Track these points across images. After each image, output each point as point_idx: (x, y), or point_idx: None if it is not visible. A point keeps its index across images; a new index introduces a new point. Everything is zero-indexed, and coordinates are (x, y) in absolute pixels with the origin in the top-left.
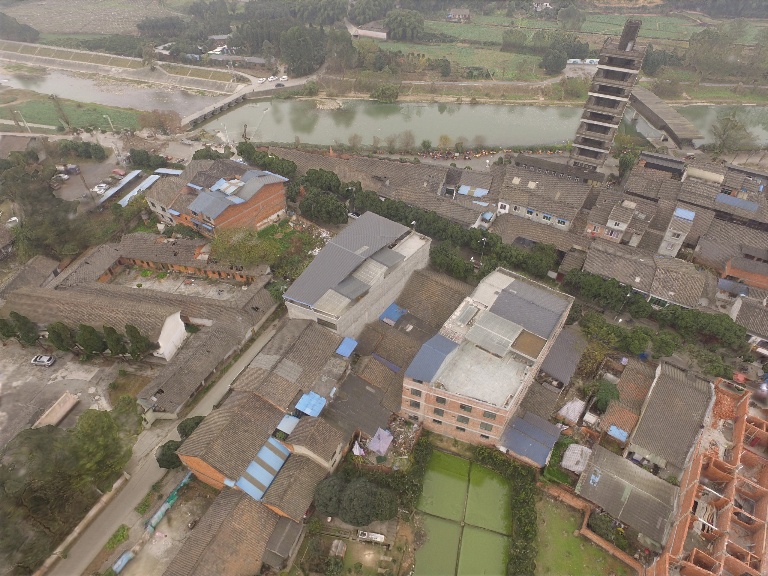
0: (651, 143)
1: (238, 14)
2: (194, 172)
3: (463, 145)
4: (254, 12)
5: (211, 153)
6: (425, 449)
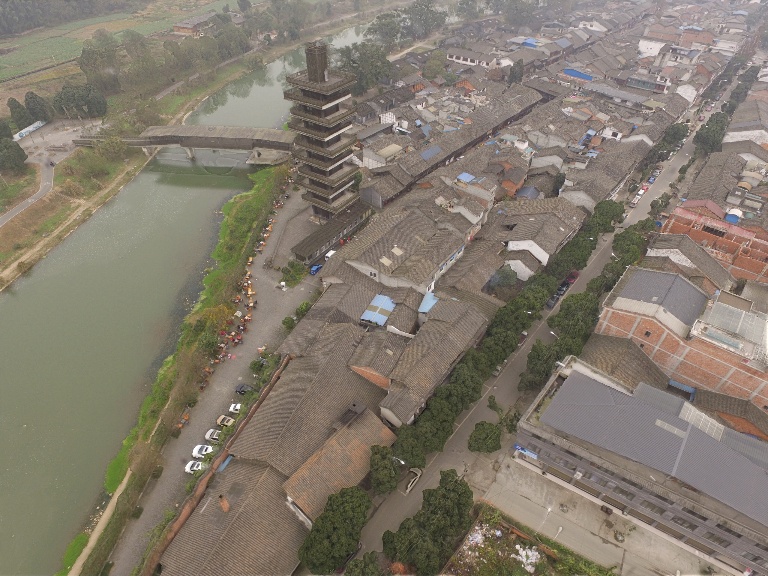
0: (257, 164)
1: None
2: None
3: (172, 309)
4: None
5: None
6: None
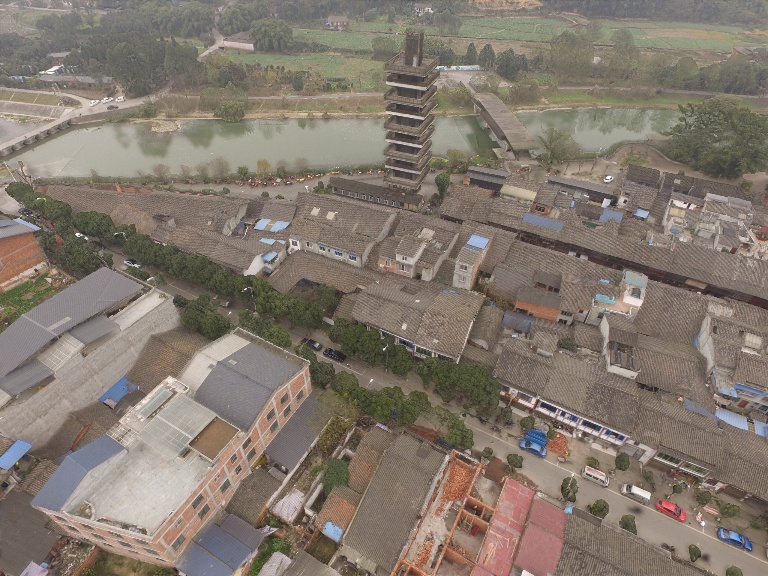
0: (495, 154)
1: (96, 27)
2: None
3: (299, 167)
4: (110, 25)
5: None
6: None
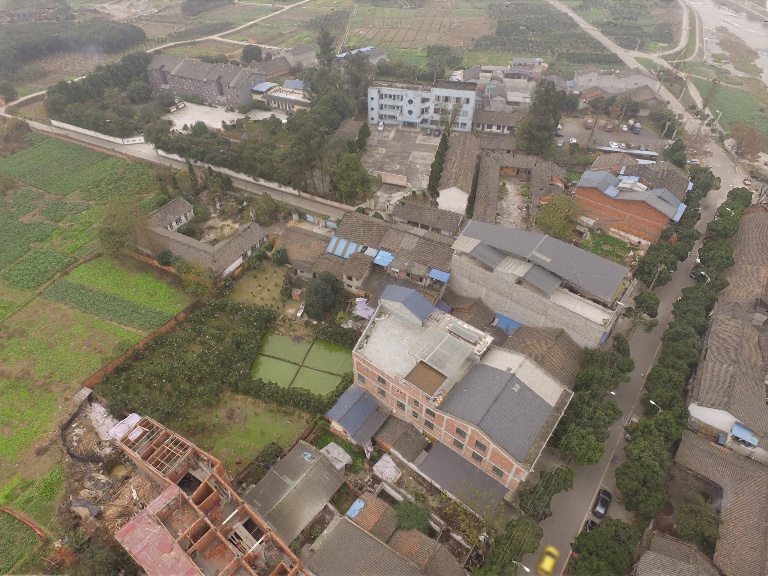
0: None
1: None
2: (652, 168)
3: None
4: None
5: (700, 173)
6: (356, 339)
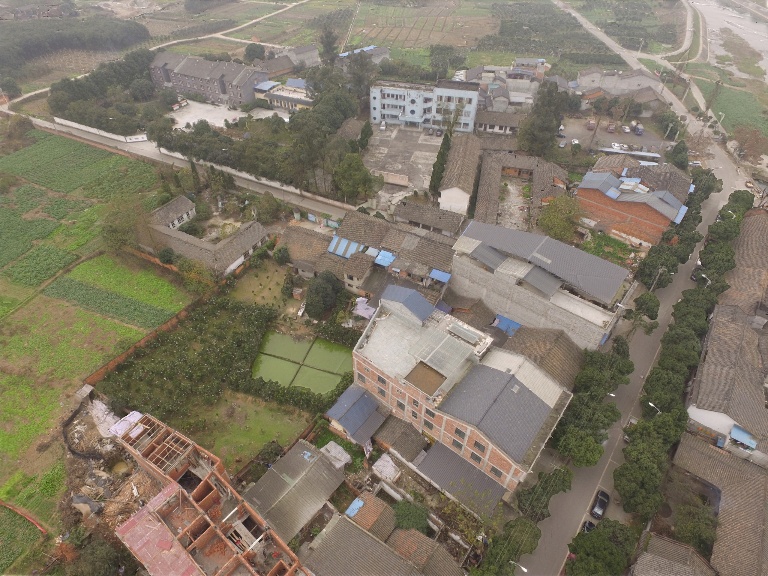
0: None
1: None
2: (654, 170)
3: None
4: None
5: (702, 175)
6: (357, 338)
